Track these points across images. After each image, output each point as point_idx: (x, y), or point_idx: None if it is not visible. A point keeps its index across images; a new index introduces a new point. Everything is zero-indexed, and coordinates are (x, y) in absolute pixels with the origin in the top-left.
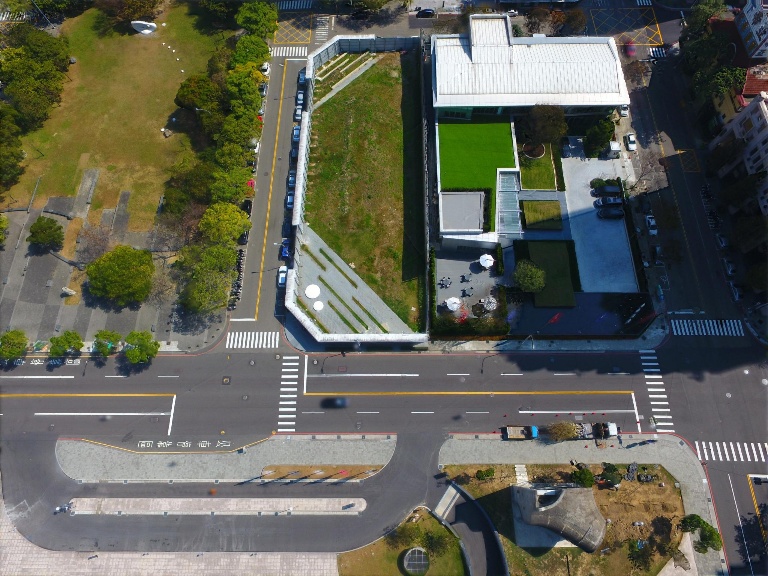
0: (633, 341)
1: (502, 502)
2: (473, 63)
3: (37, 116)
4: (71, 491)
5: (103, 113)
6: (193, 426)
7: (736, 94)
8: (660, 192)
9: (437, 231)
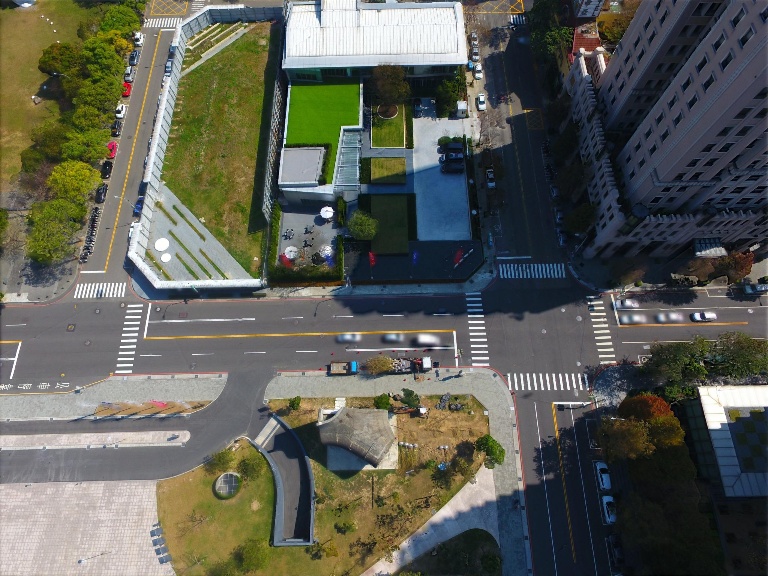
0: (461, 284)
1: (318, 431)
2: (321, 27)
3: None
4: None
5: None
6: (35, 370)
7: (568, 53)
8: (503, 148)
9: None
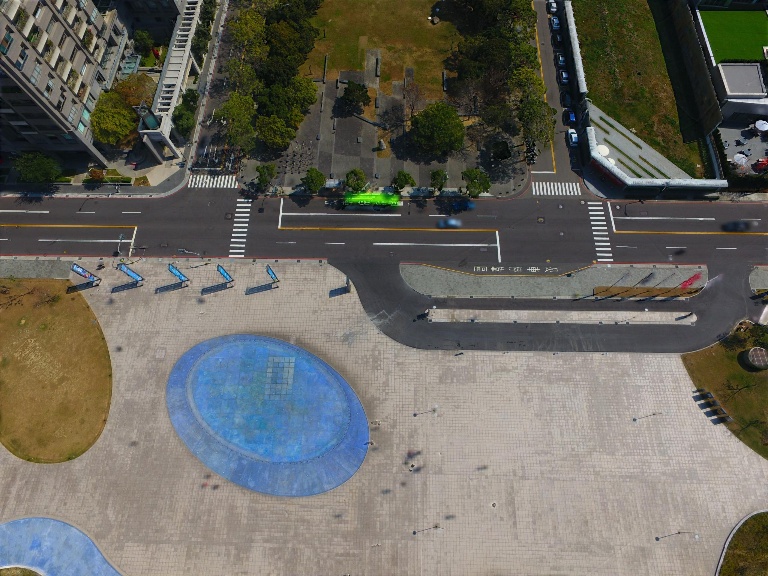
0: None
1: None
2: None
3: (320, 1)
4: (424, 304)
5: (370, 4)
6: (520, 255)
7: None
8: None
9: None
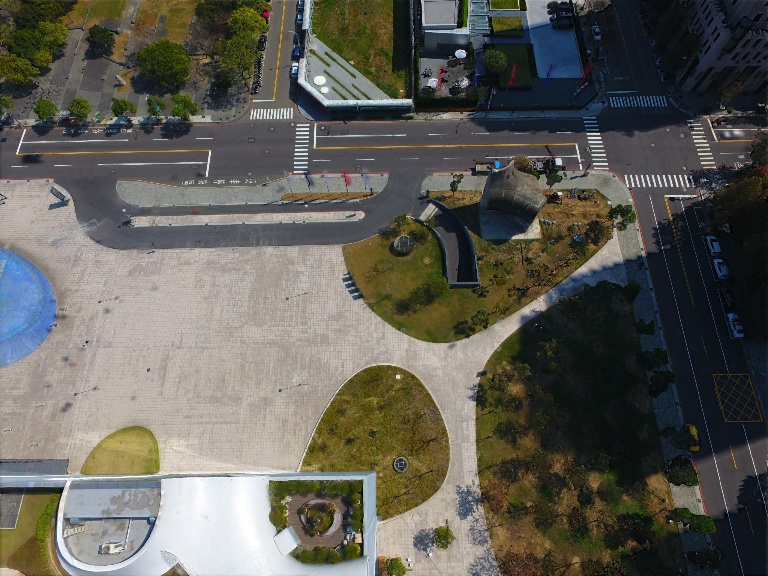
0: (578, 111)
1: (471, 212)
2: None
3: None
4: (131, 212)
5: None
6: (226, 170)
7: None
8: (605, 11)
9: (421, 38)
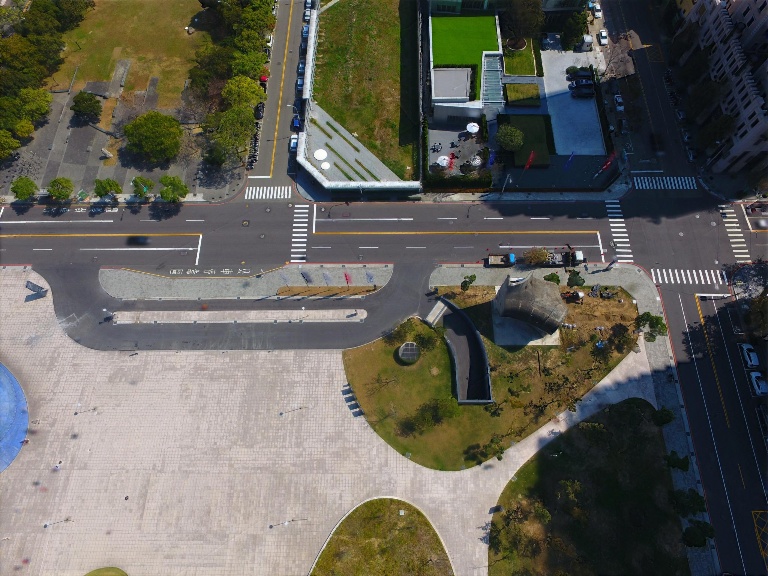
0: (600, 193)
1: (483, 312)
2: None
3: (75, 14)
4: (113, 306)
5: (133, 15)
6: (217, 258)
7: None
8: (628, 78)
9: (430, 107)
